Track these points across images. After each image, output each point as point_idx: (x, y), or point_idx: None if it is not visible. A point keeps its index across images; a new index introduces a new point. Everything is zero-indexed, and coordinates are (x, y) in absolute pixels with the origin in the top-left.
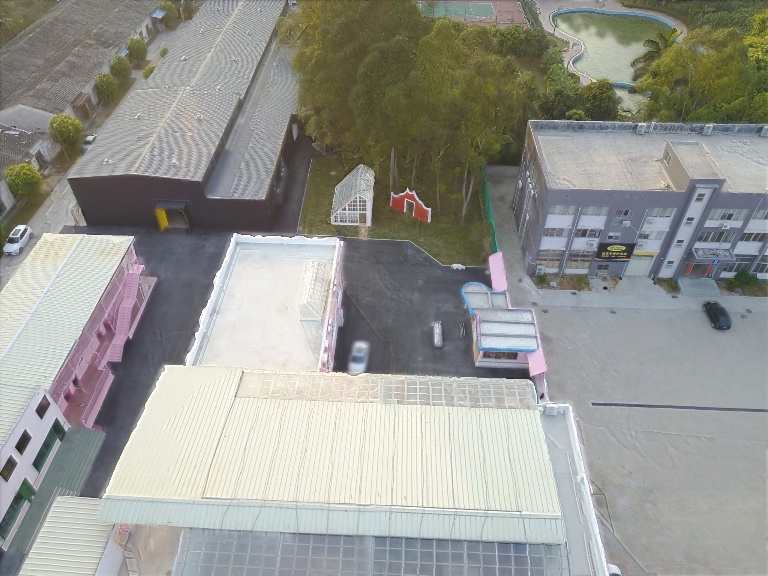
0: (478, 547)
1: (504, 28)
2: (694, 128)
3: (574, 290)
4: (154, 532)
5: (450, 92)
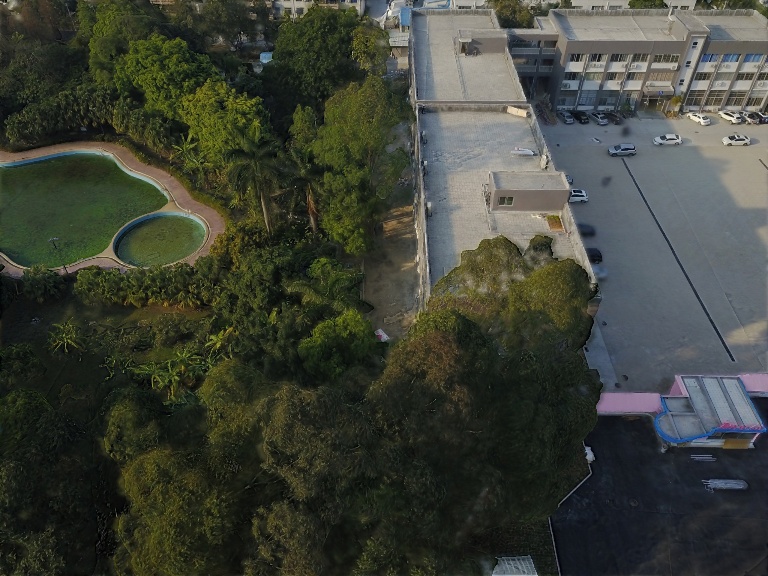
0: None
1: None
2: None
3: (583, 348)
4: None
5: None
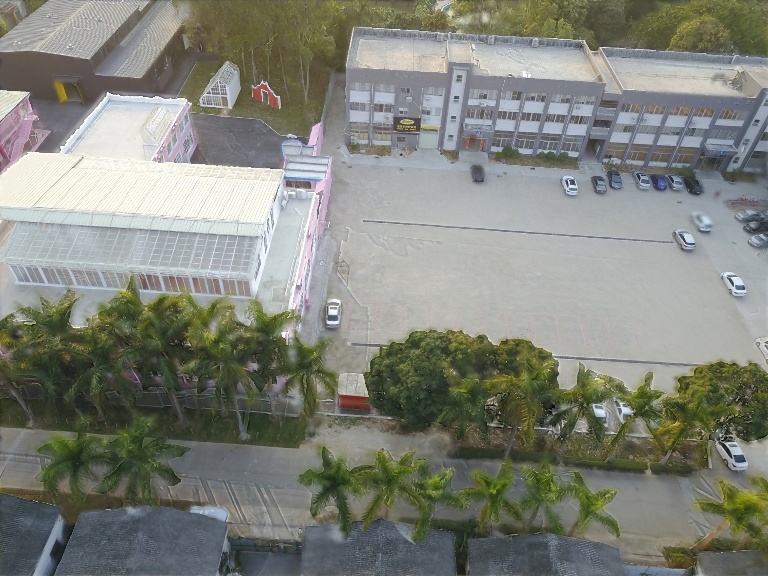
0: (206, 237)
1: None
2: (482, 39)
3: (377, 155)
4: (6, 244)
5: None
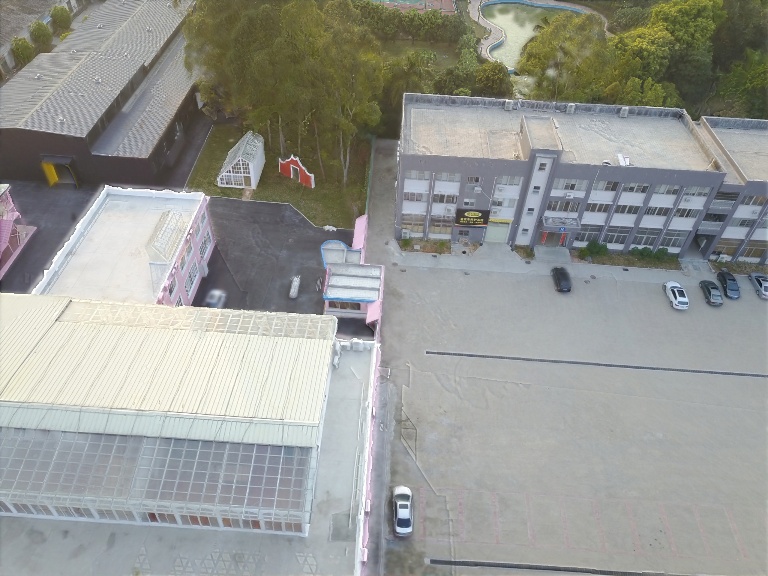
0: (239, 448)
1: (423, 13)
2: (559, 107)
3: (435, 253)
4: None
5: (312, 59)
